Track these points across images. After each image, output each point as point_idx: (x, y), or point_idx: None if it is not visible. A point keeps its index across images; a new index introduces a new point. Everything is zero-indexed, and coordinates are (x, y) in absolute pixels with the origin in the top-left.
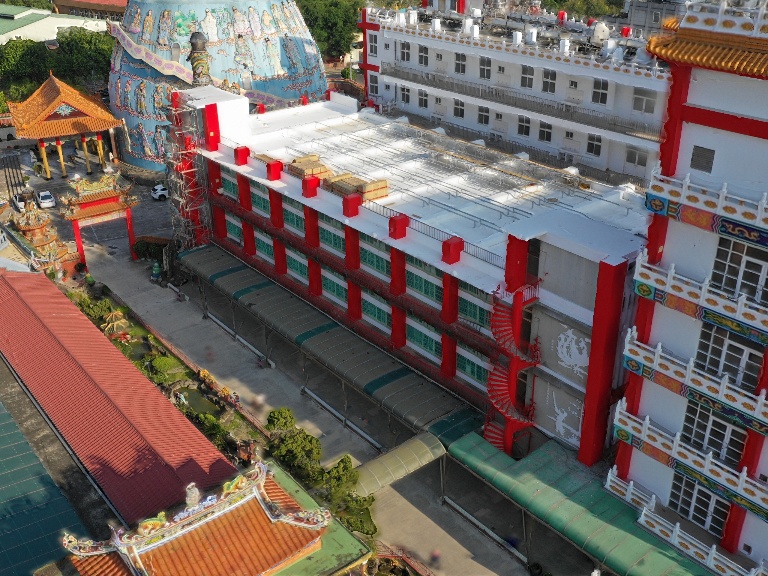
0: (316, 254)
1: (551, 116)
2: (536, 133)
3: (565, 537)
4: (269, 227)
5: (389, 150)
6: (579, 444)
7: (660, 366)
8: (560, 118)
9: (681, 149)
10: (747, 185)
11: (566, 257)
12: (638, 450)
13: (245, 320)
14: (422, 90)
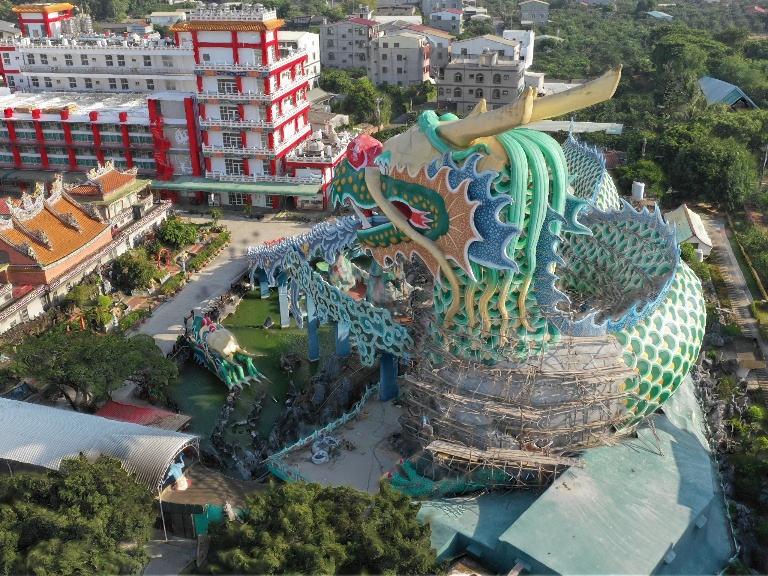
0: (49, 143)
1: (129, 75)
2: (120, 86)
3: (200, 190)
4: (12, 141)
5: (54, 102)
6: (192, 172)
7: (212, 124)
8: (134, 75)
9: (200, 56)
10: (221, 61)
11: (171, 103)
12: (213, 160)
13: (3, 197)
14: (47, 78)
